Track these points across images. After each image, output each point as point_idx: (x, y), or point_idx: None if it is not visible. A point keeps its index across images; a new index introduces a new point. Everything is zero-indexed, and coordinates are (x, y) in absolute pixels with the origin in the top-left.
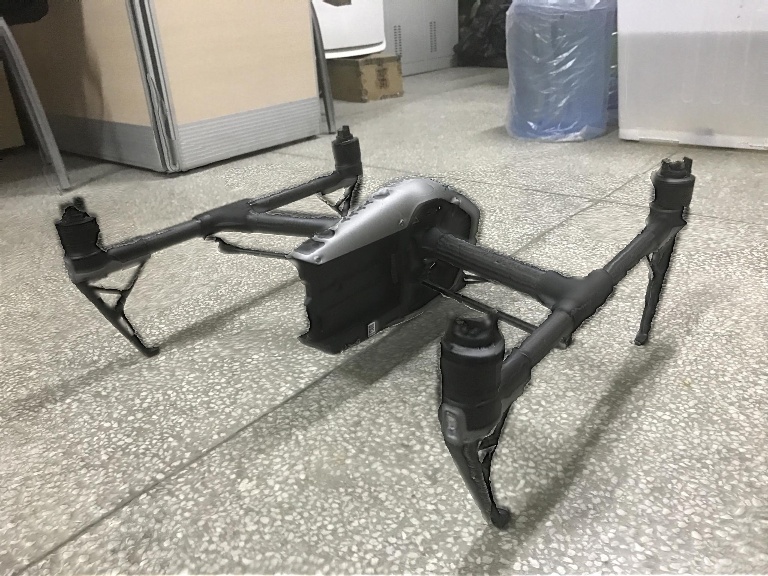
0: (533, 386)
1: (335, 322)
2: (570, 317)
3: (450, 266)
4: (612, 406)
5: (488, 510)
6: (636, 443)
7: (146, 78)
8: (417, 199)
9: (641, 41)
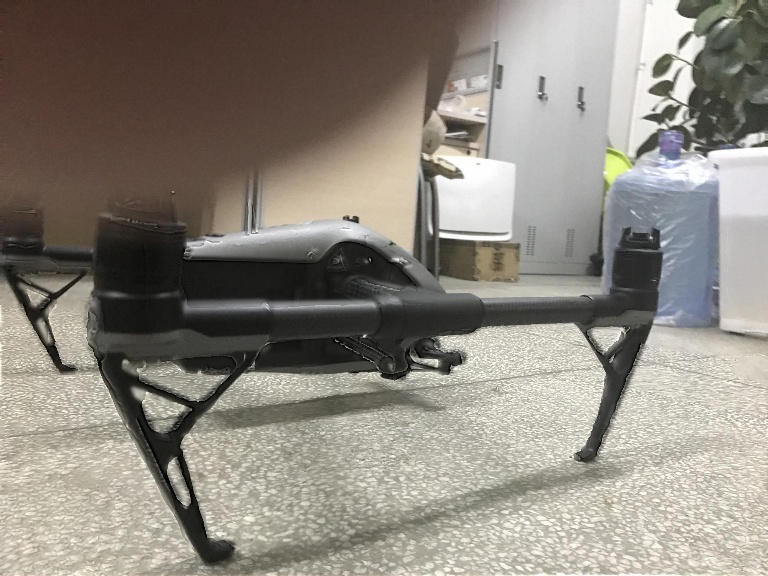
0: (407, 464)
1: None
2: (376, 308)
3: None
4: (484, 498)
5: (174, 510)
6: (478, 535)
7: (247, 203)
8: (338, 238)
9: (744, 224)
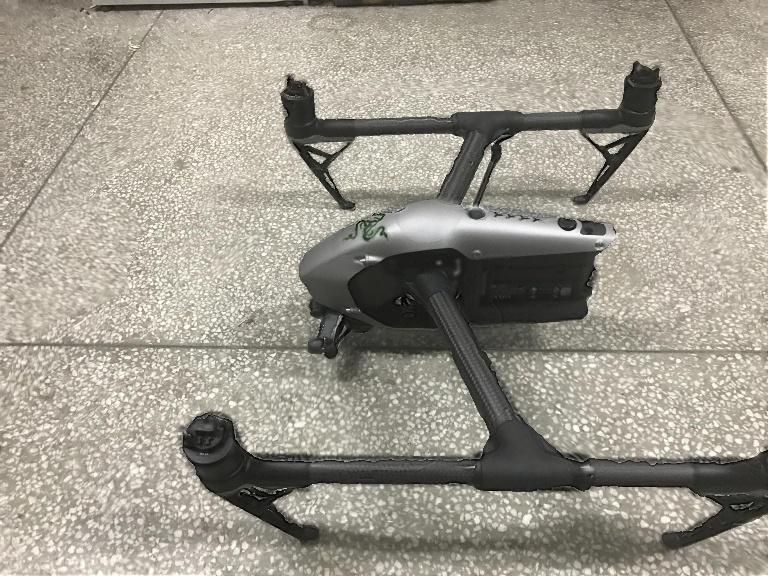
0: None
1: None
2: None
3: None
4: None
5: None
6: None
7: None
8: None
9: None
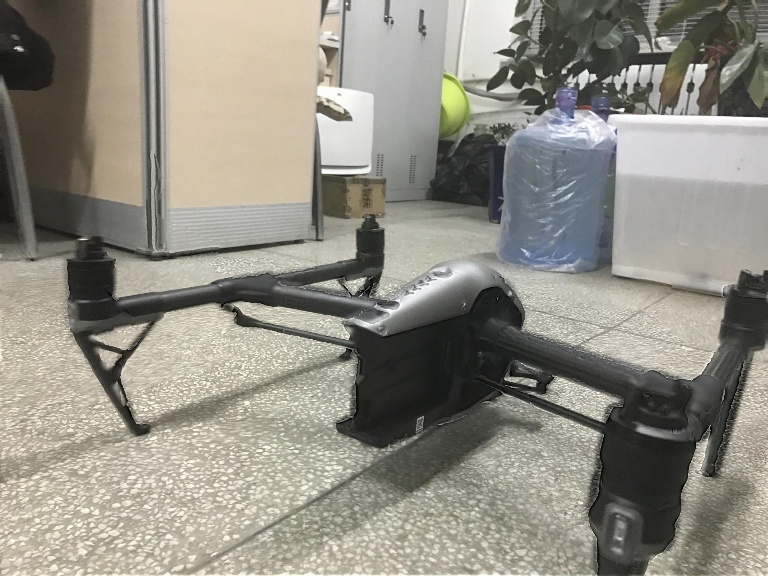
0: None
1: (383, 410)
2: (699, 421)
3: (495, 367)
4: (702, 543)
5: None
6: None
7: (149, 155)
8: (481, 284)
9: (640, 186)
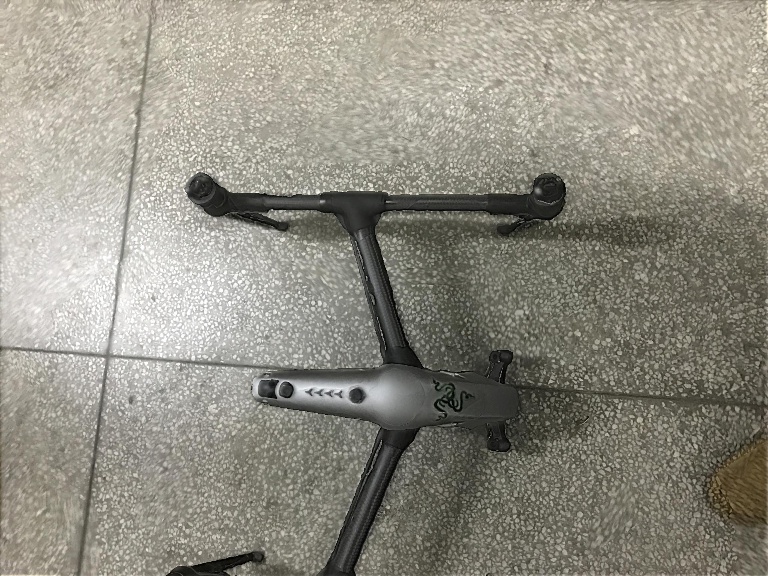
0: (387, 523)
1: None
2: None
3: None
4: None
5: None
6: None
7: None
8: (381, 421)
9: None
